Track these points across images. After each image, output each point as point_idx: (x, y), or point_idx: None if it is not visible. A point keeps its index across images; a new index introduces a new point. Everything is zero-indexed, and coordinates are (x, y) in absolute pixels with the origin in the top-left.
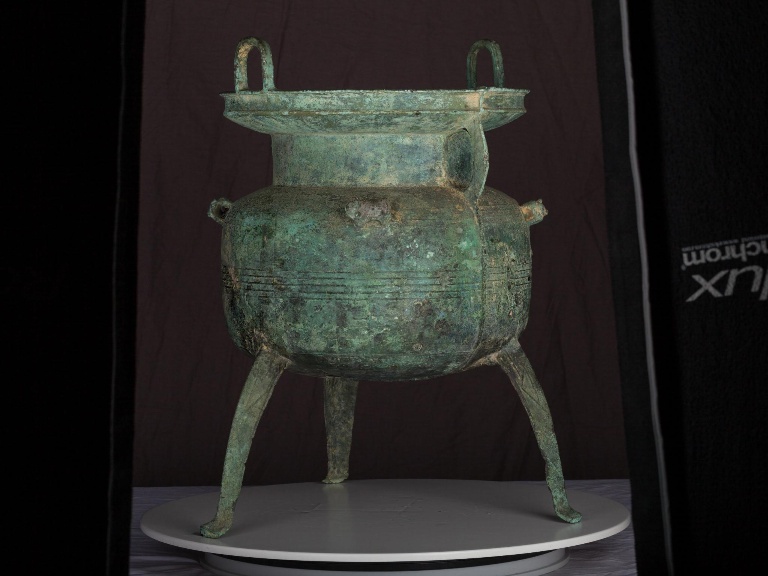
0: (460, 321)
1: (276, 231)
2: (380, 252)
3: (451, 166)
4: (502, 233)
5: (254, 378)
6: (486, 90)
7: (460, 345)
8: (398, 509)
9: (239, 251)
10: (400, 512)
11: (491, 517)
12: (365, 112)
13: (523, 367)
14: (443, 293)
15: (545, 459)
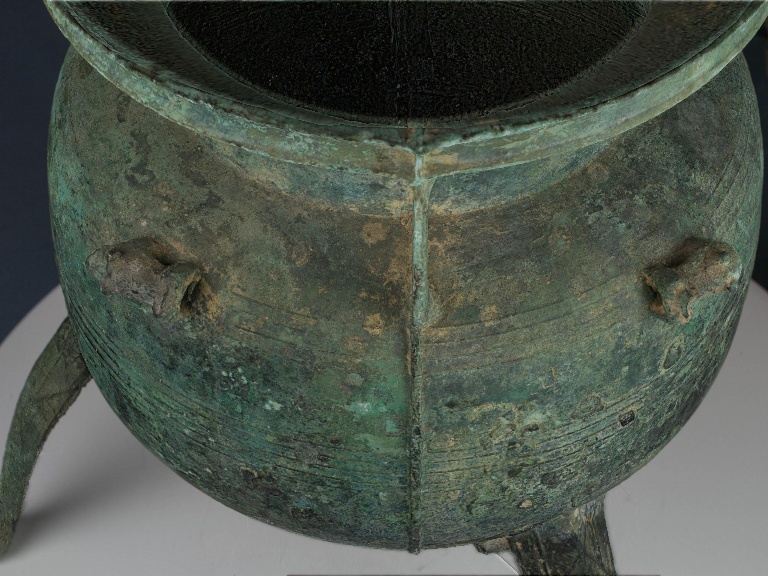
0: (353, 520)
1: (51, 165)
2: (170, 355)
3: (437, 181)
4: (496, 385)
5: (57, 353)
6: (420, 153)
7: (366, 543)
8: None
9: None
10: (435, 555)
11: None
12: (129, 94)
13: (565, 575)
14: (305, 473)
15: None
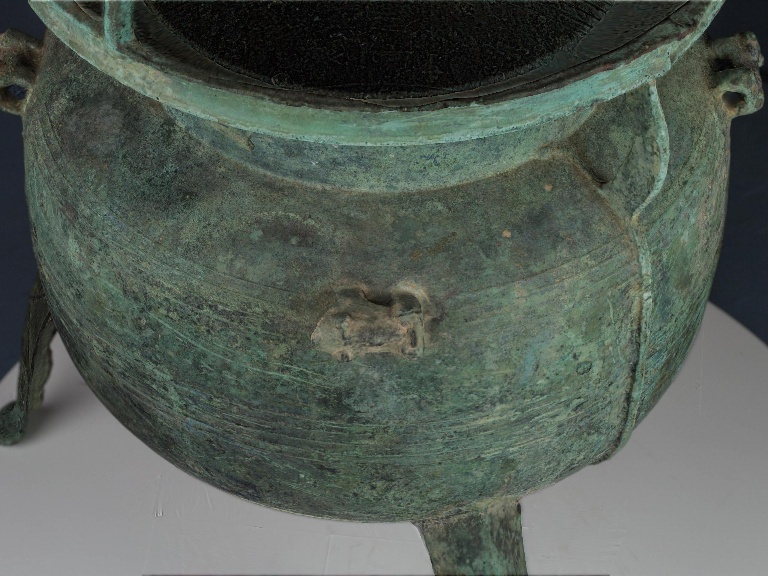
0: None
1: None
2: None
3: None
4: None
5: None
6: None
7: None
8: (341, 552)
9: None
10: (335, 521)
11: (159, 471)
12: None
13: None
14: (227, 1)
15: (50, 340)
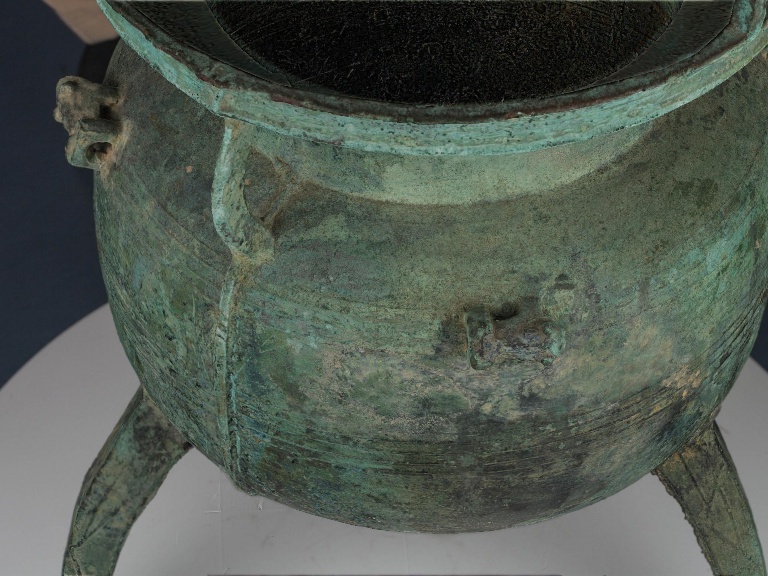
0: None
1: None
2: None
3: None
4: None
5: None
6: None
7: None
8: None
9: (707, 323)
10: None
11: None
12: None
13: None
14: None
15: None
